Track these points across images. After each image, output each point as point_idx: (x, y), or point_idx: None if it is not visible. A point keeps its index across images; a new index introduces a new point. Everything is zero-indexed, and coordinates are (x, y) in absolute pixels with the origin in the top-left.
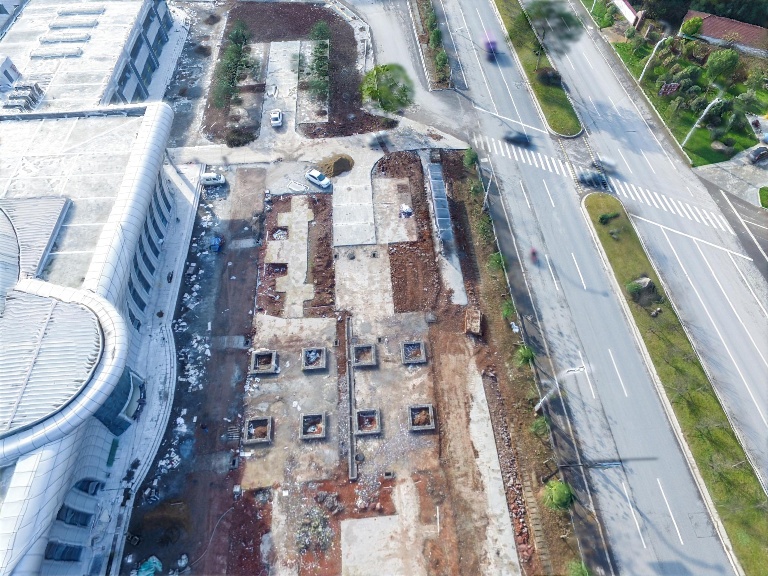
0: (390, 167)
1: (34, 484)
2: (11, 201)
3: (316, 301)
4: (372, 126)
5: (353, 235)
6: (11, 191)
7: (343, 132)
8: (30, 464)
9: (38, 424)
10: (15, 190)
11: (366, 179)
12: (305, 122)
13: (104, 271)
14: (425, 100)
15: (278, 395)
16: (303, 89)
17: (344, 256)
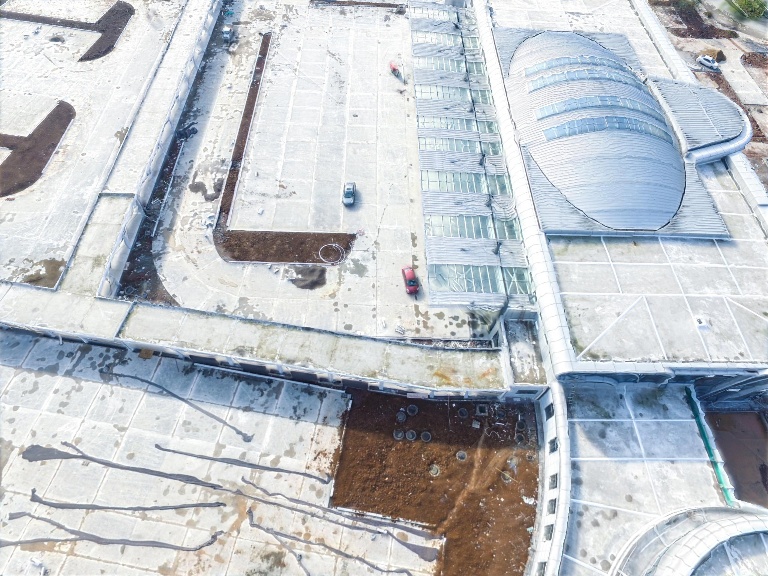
0: (753, 61)
1: (747, 167)
2: (590, 34)
3: (753, 133)
4: (723, 34)
5: (754, 99)
6: (577, 30)
7: (704, 36)
8: (738, 158)
9: (732, 140)
10: (579, 30)
11: (741, 67)
12: (671, 27)
13: (692, 76)
14: (748, 22)
15: (762, 180)
16: (654, 5)
17: (755, 110)
